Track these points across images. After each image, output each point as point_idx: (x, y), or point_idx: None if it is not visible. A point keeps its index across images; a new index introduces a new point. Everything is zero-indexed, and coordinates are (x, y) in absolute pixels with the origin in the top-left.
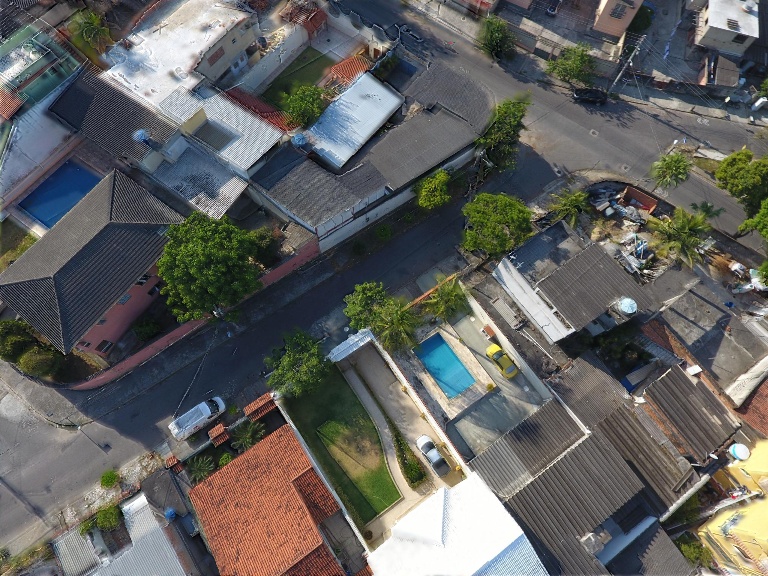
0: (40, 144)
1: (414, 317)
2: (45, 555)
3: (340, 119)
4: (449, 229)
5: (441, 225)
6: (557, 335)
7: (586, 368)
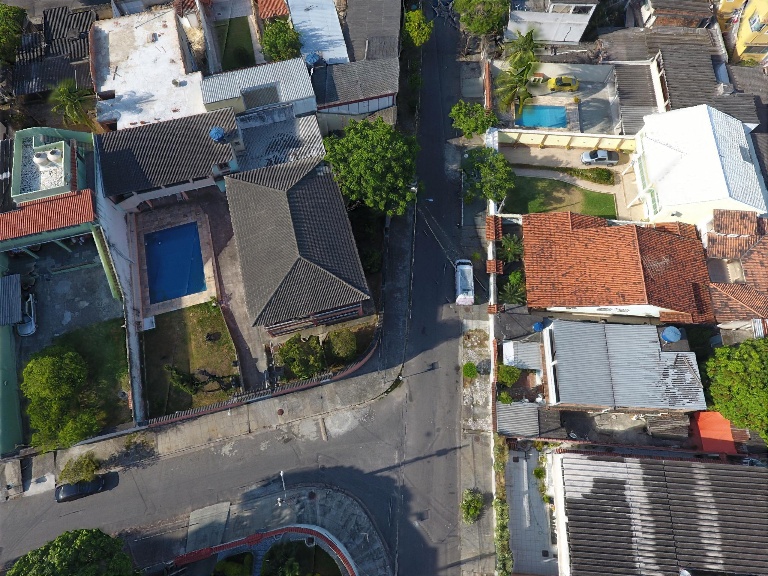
0: (119, 239)
1: (493, 109)
2: (504, 439)
3: (310, 36)
4: (441, 55)
5: (433, 57)
6: (580, 30)
7: (609, 37)
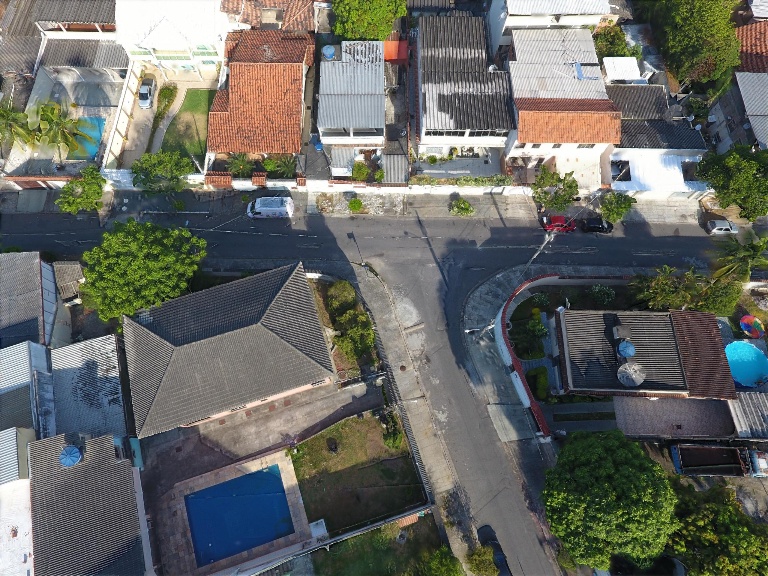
0: None
1: None
2: (412, 177)
3: None
4: None
5: None
6: None
7: (1, 66)
